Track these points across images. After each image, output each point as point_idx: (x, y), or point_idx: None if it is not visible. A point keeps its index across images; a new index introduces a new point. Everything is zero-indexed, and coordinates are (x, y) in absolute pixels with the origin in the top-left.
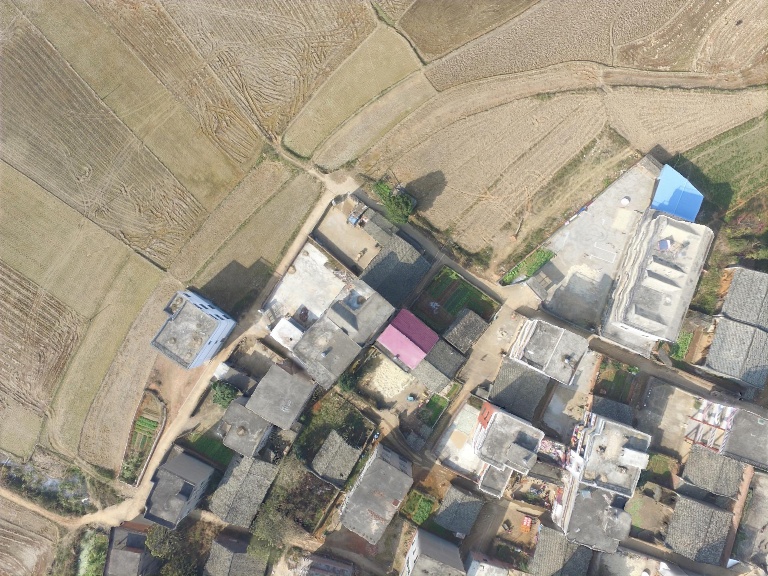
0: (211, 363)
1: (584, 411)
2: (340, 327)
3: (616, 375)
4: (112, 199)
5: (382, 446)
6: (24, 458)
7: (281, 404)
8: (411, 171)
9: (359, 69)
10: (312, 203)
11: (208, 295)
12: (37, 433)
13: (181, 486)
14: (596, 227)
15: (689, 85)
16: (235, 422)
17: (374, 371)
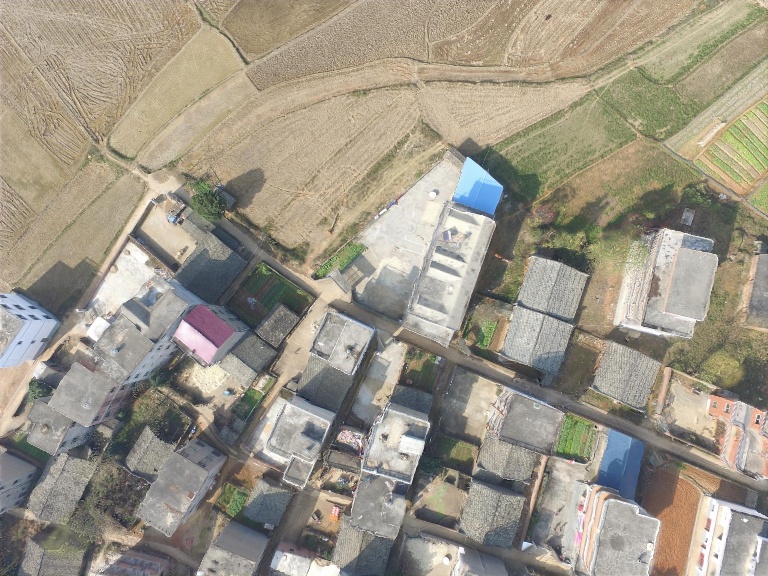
0: (36, 363)
1: (386, 401)
2: (134, 324)
3: (424, 365)
4: None
5: (197, 440)
6: None
7: (82, 401)
8: (231, 169)
9: (183, 70)
10: (136, 203)
11: (34, 296)
12: None
13: None
14: (406, 220)
15: (500, 79)
16: (39, 420)
17: (193, 367)
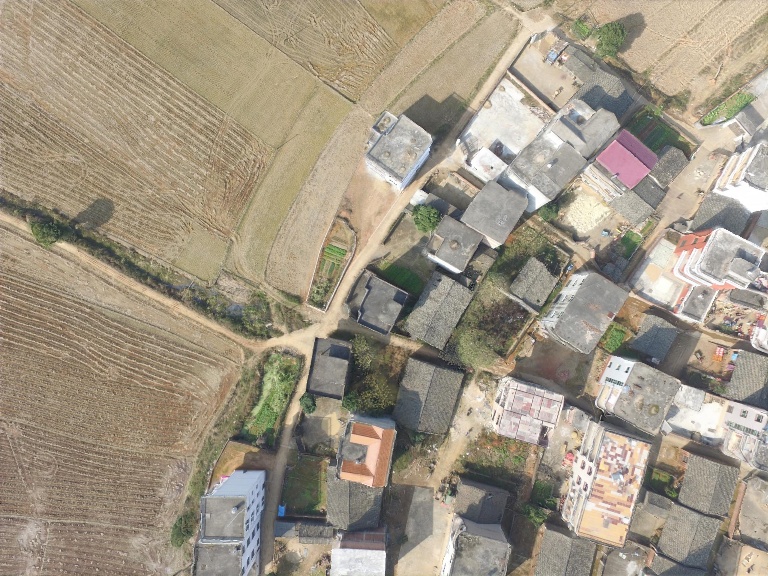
0: (402, 194)
1: None
2: (565, 141)
3: None
4: (301, 29)
5: None
6: (209, 282)
7: (497, 218)
8: (610, 12)
9: None
10: (507, 41)
11: None
12: (222, 258)
13: (393, 295)
14: None
15: None
16: (448, 236)
17: (568, 206)
